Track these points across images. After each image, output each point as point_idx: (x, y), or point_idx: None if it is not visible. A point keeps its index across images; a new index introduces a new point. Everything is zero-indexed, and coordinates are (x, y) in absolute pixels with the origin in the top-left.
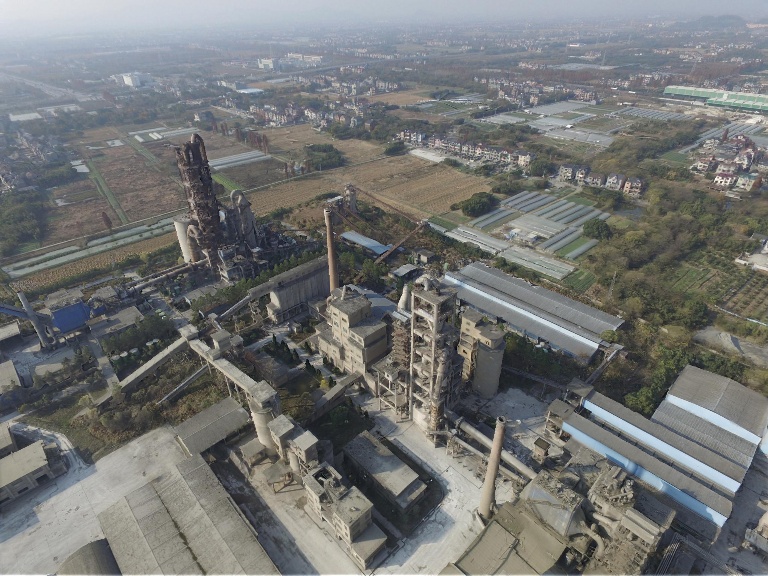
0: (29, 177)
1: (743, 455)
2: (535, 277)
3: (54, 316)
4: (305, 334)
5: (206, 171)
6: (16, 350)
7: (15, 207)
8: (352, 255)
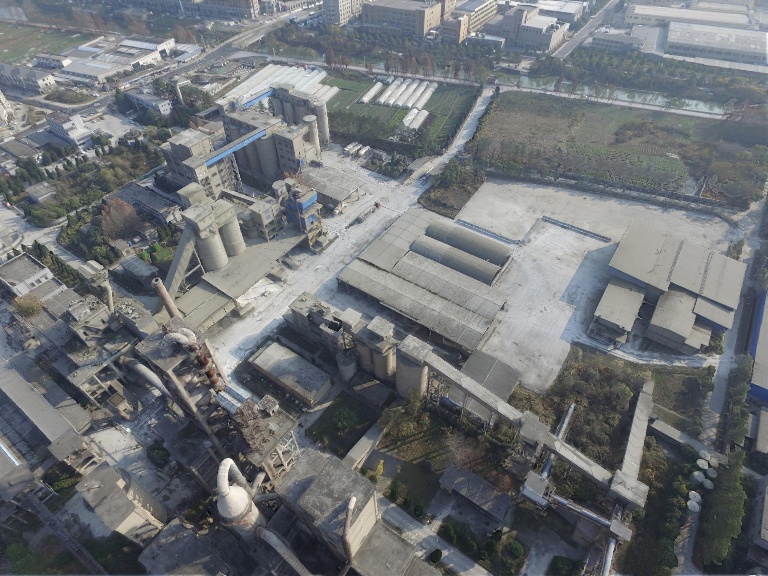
0: None
1: None
2: None
3: None
4: None
5: None
6: None
7: None
8: None
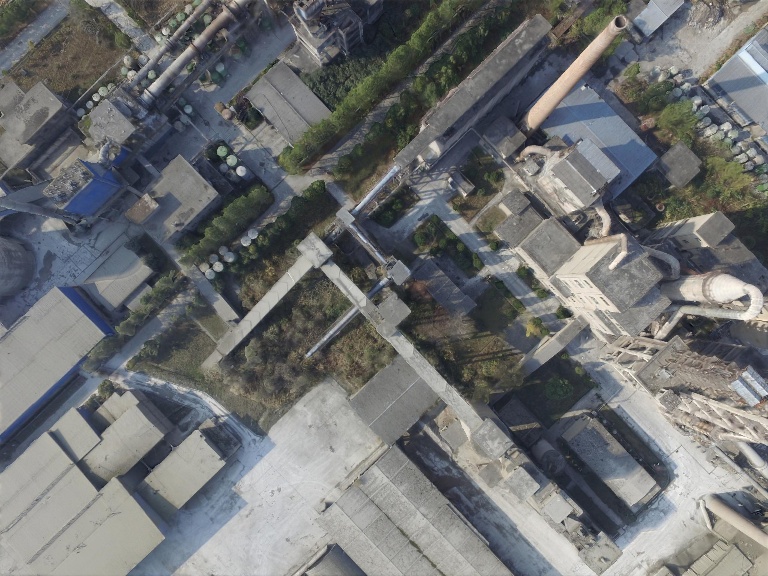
0: None
1: None
2: None
3: (67, 210)
4: (479, 199)
5: None
6: (30, 227)
7: None
8: None
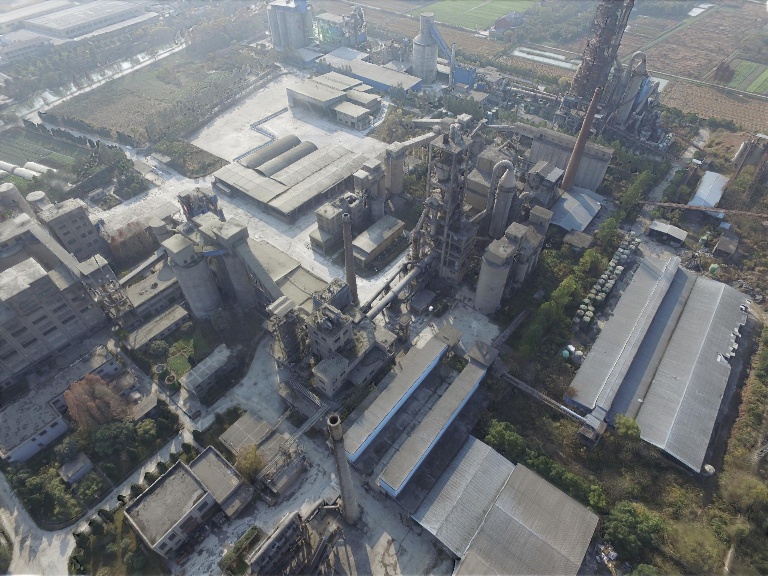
0: (645, 0)
1: (437, 525)
2: (767, 371)
3: (455, 70)
4: None
5: (623, 17)
6: (442, 83)
7: (587, 14)
8: (644, 175)
